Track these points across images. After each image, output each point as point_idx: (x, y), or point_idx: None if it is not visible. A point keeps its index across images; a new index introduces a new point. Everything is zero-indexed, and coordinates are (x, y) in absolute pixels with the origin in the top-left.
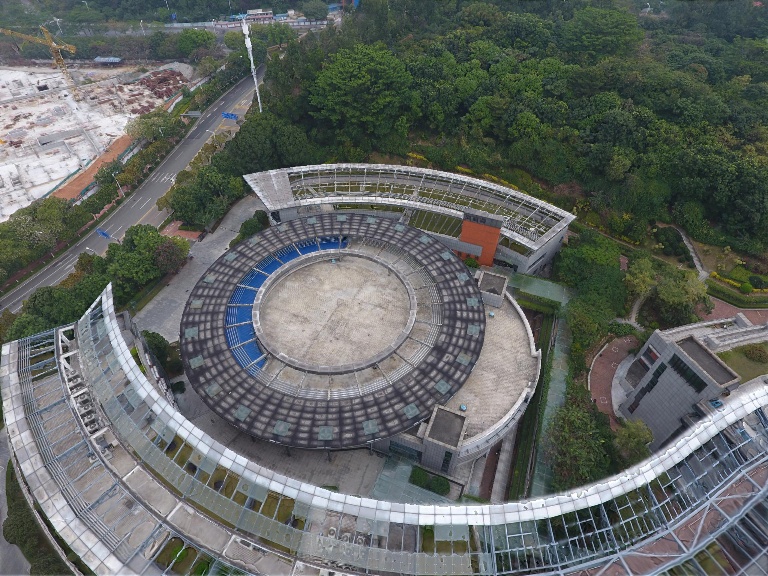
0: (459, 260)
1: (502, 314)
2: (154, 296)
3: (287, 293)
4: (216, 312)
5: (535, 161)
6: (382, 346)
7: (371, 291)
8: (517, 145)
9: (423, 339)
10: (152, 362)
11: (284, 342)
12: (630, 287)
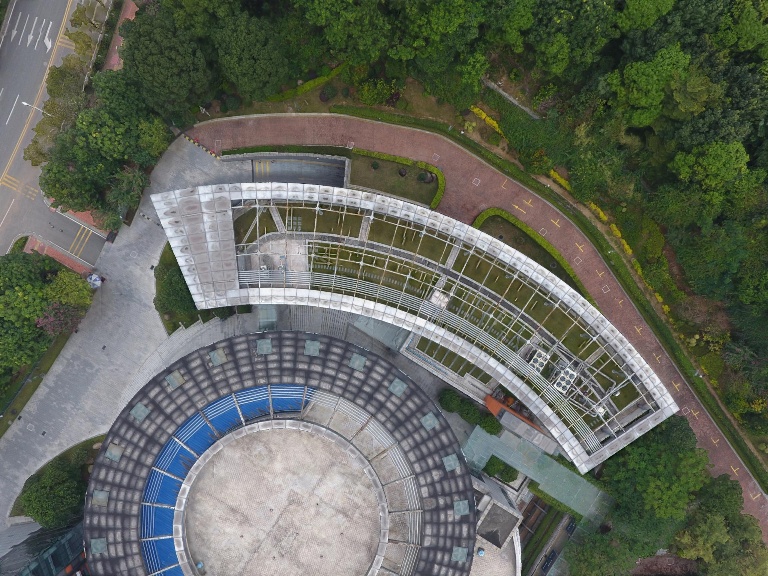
0: (467, 473)
1: (495, 552)
2: (60, 350)
3: (224, 469)
4: (127, 515)
5: (687, 233)
6: (334, 575)
7: (336, 484)
8: (671, 206)
9: (386, 574)
10: (60, 567)
11: (217, 551)
12: (680, 542)
